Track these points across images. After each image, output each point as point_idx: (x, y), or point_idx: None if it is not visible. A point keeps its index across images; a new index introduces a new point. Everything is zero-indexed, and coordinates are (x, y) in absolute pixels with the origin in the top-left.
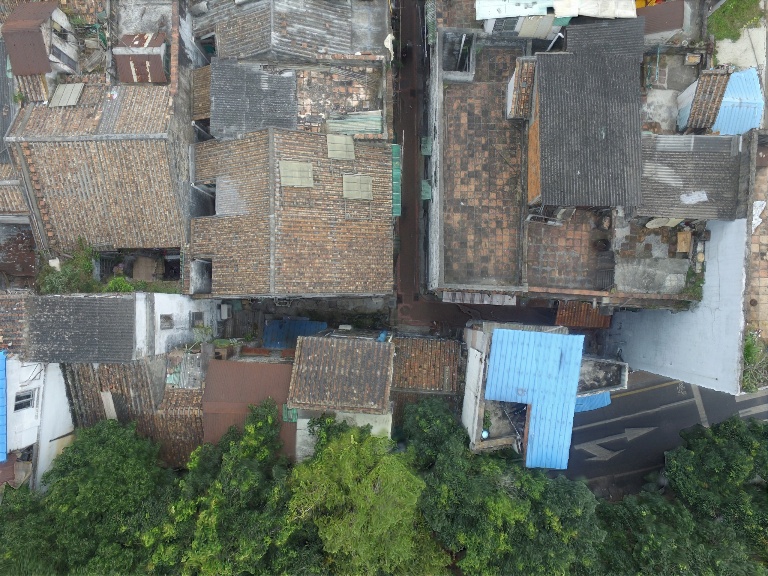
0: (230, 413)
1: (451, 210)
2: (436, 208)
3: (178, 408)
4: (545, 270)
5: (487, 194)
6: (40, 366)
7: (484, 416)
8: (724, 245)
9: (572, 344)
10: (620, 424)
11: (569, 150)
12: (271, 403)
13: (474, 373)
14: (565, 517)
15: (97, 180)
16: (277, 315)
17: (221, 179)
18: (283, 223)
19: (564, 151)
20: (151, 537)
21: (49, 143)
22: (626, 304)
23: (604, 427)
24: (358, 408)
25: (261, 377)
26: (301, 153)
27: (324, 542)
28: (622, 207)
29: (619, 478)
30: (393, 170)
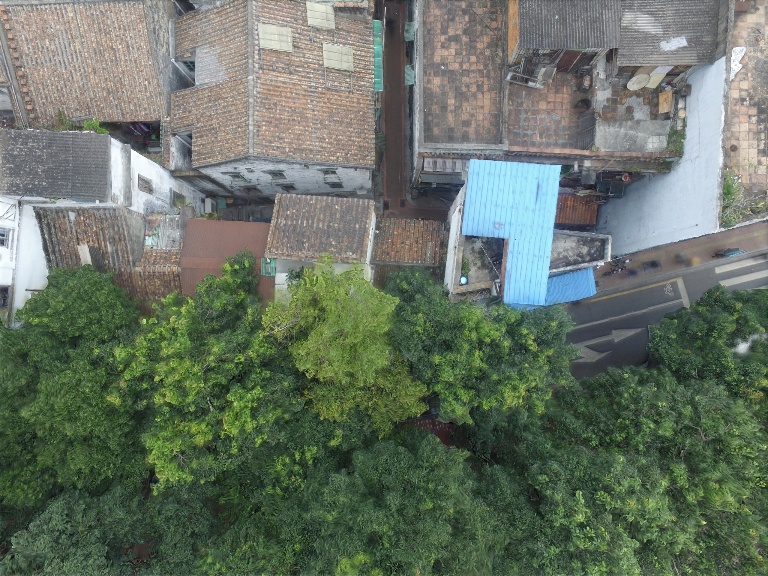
0: (208, 268)
1: (431, 74)
2: (417, 78)
3: (156, 265)
4: (526, 134)
5: (467, 58)
6: (15, 208)
7: (462, 261)
8: (704, 92)
9: (549, 174)
10: (607, 326)
11: None
12: (249, 254)
13: (454, 230)
14: (541, 340)
15: (75, 47)
16: None
17: (201, 49)
18: (262, 86)
19: None
20: (123, 351)
21: (26, 7)
22: (608, 167)
23: (591, 329)
24: (336, 257)
25: (240, 234)
26: (280, 18)
27: None
28: (603, 69)
29: None
30: (374, 46)
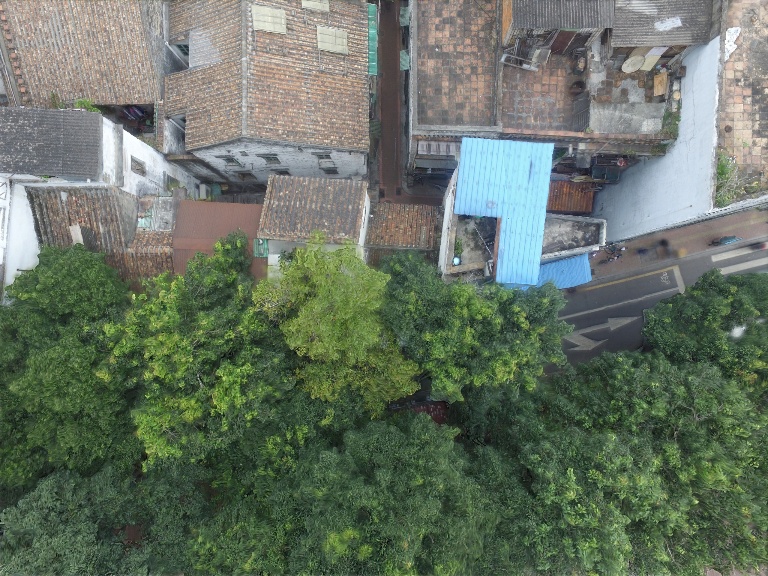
0: (200, 249)
1: (425, 56)
2: None
3: (148, 246)
4: (520, 116)
5: (462, 40)
6: (6, 187)
7: (455, 242)
8: (699, 73)
9: (542, 152)
10: (603, 314)
11: None
12: (241, 235)
13: (447, 211)
14: (533, 318)
15: (68, 28)
16: None
17: (194, 32)
18: (255, 68)
19: None
20: (112, 327)
21: None
22: (602, 150)
23: (587, 317)
24: (329, 237)
25: (232, 216)
26: (274, 0)
27: None
28: (598, 51)
29: None
30: (369, 29)
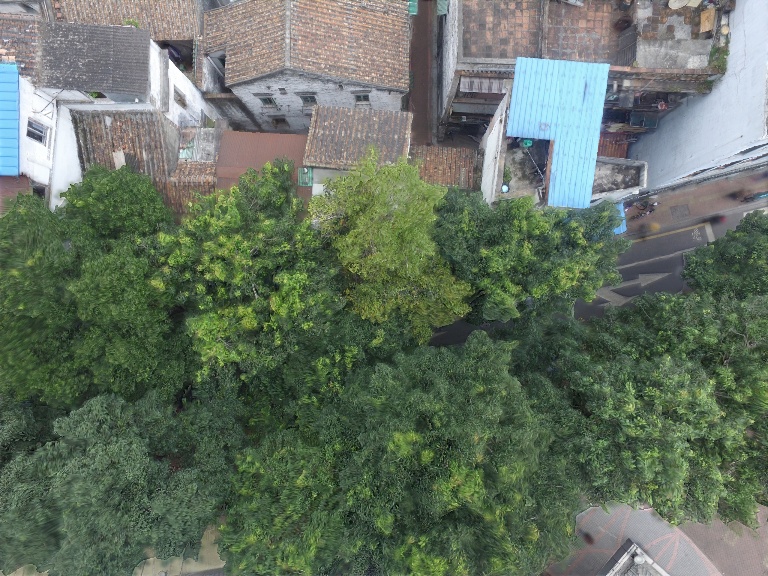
0: None
1: None
2: None
3: (191, 176)
4: (565, 52)
5: None
6: (52, 107)
7: (504, 169)
8: (750, 3)
9: (597, 73)
10: (634, 270)
11: None
12: (287, 162)
13: (493, 144)
14: (589, 236)
15: None
16: None
17: None
18: None
19: None
20: (167, 236)
21: None
22: (647, 87)
23: None
24: None
25: (276, 146)
26: None
27: (343, 260)
28: None
29: None
30: None
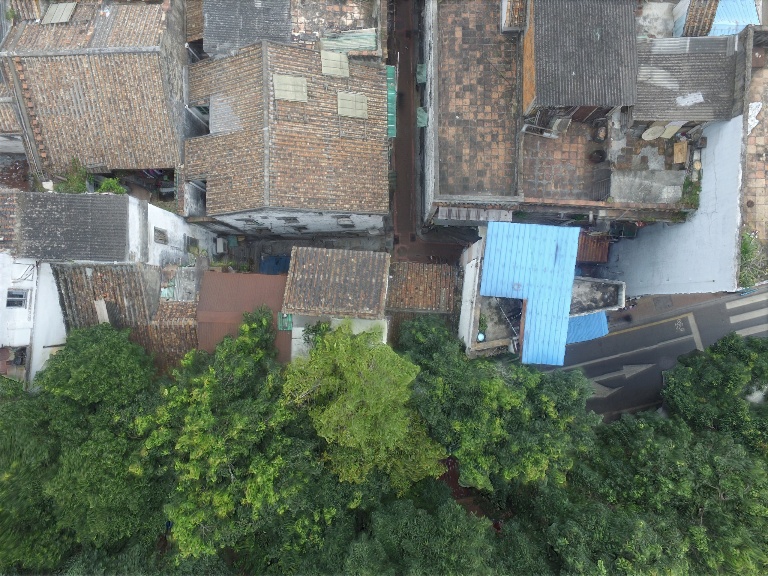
0: (225, 322)
1: (446, 124)
2: (431, 126)
3: (172, 319)
4: (541, 183)
5: (482, 107)
6: (33, 268)
7: (480, 318)
8: (720, 147)
9: (568, 236)
10: (618, 361)
11: (564, 51)
12: (266, 310)
13: (470, 282)
14: (561, 405)
15: (90, 97)
16: (273, 255)
17: (215, 97)
18: (277, 137)
19: (559, 52)
20: (144, 421)
21: (41, 58)
22: (622, 217)
23: (602, 364)
24: (353, 313)
25: (256, 287)
26: (295, 68)
27: None
28: (618, 119)
29: (617, 415)
30: (388, 91)
